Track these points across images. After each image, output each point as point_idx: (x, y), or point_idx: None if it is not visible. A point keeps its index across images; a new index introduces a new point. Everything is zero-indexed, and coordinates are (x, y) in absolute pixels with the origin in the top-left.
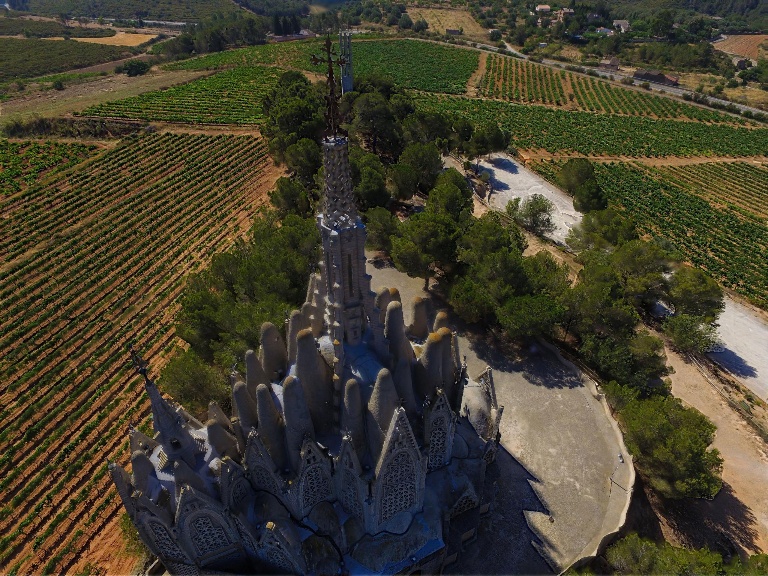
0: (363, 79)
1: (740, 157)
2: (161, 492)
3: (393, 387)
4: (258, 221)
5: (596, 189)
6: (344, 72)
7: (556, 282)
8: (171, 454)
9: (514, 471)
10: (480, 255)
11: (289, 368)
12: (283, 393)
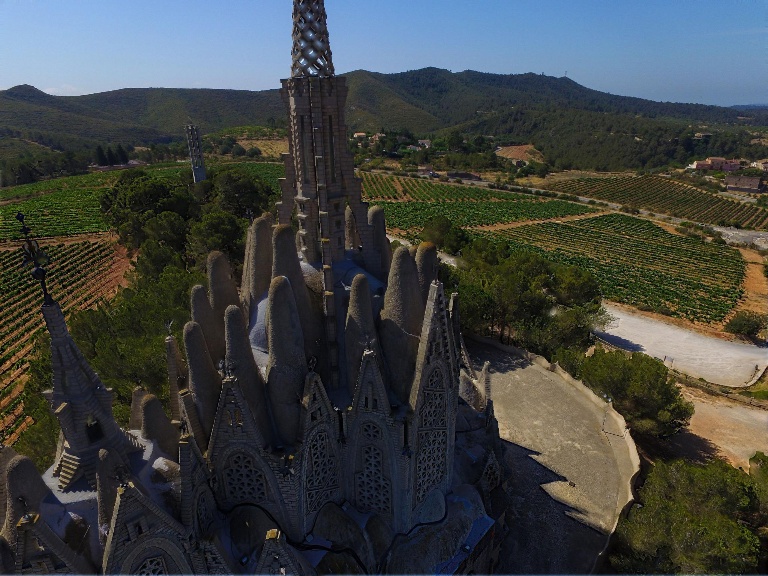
0: (216, 171)
1: (546, 220)
2: (70, 525)
3: None
4: (123, 289)
5: (461, 233)
6: (195, 164)
7: (472, 281)
8: (85, 452)
9: (511, 451)
10: None
11: (255, 309)
12: (271, 302)
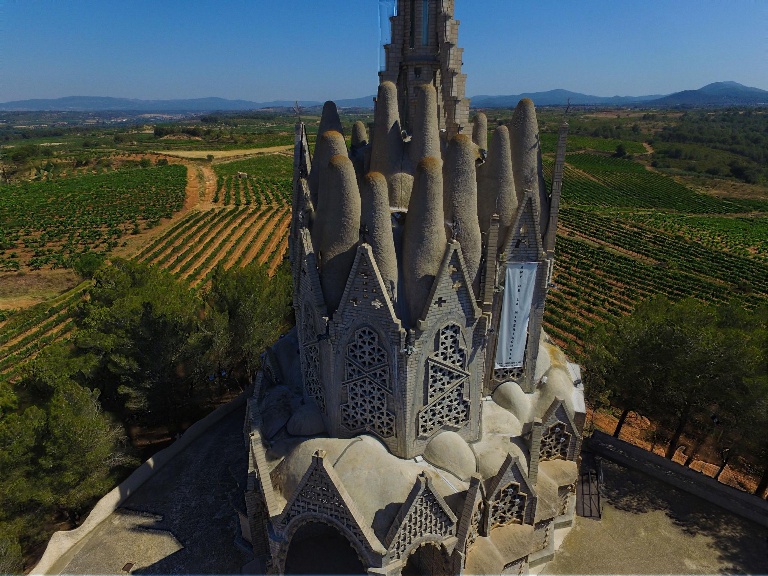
0: None
1: None
2: None
3: (321, 123)
4: None
5: None
6: None
7: None
8: None
9: None
10: None
11: None
12: None
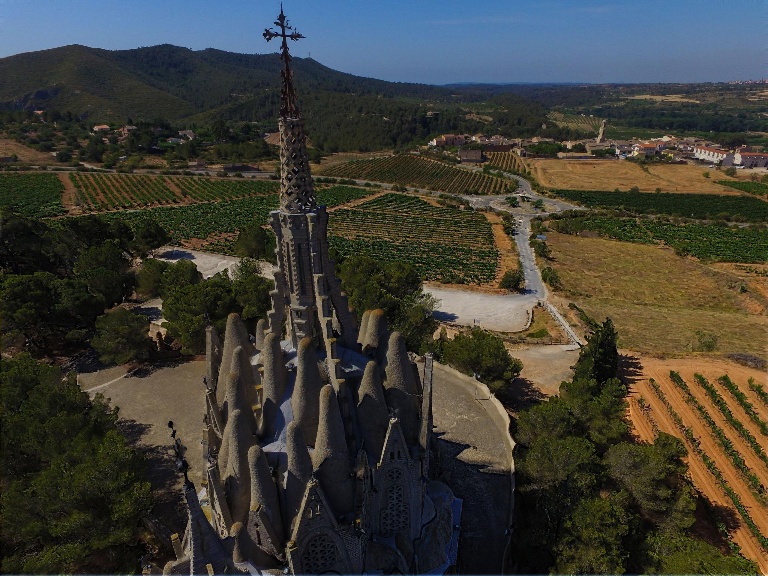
0: None
1: (335, 207)
2: None
3: None
4: None
5: None
6: None
7: None
8: None
9: None
10: (257, 308)
11: (278, 411)
12: (327, 409)
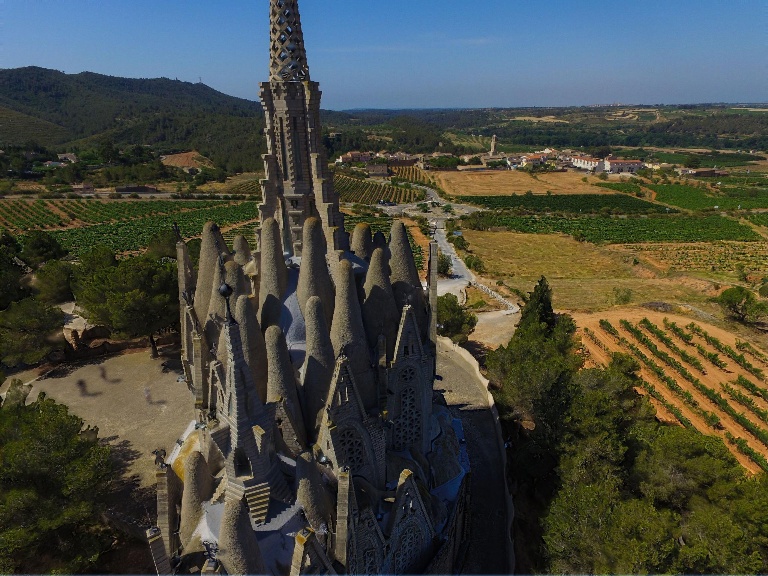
0: None
1: (248, 221)
2: None
3: None
4: None
5: None
6: None
7: None
8: (269, 474)
9: None
10: None
11: (283, 308)
12: (347, 283)
